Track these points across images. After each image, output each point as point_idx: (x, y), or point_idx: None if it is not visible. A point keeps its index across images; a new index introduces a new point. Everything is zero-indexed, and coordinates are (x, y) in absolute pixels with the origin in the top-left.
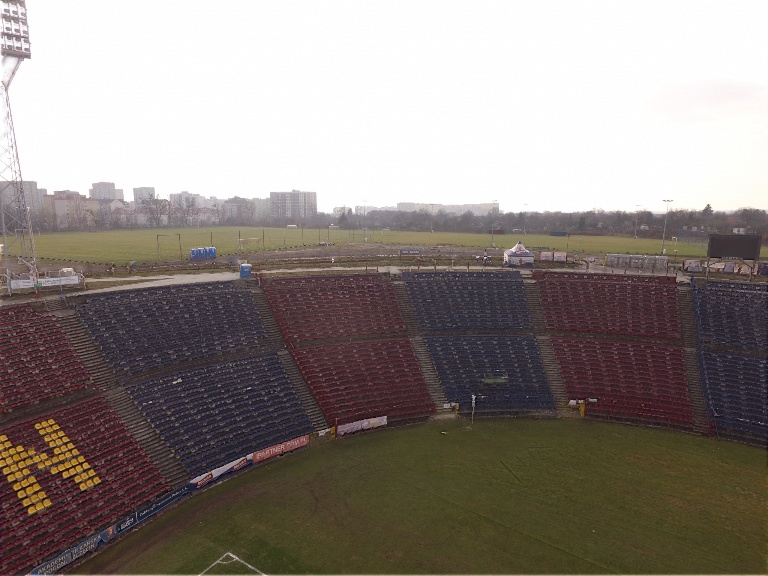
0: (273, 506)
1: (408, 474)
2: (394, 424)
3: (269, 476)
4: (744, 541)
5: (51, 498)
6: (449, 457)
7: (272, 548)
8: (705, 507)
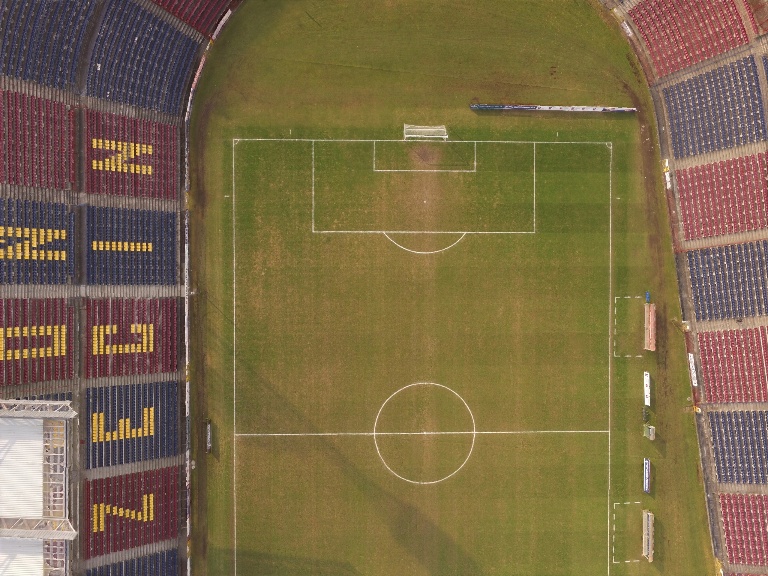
0: (227, 108)
1: (268, 51)
2: (232, 4)
3: (208, 92)
4: (412, 20)
5: (147, 165)
6: (280, 24)
7: (247, 128)
8: (400, 1)
